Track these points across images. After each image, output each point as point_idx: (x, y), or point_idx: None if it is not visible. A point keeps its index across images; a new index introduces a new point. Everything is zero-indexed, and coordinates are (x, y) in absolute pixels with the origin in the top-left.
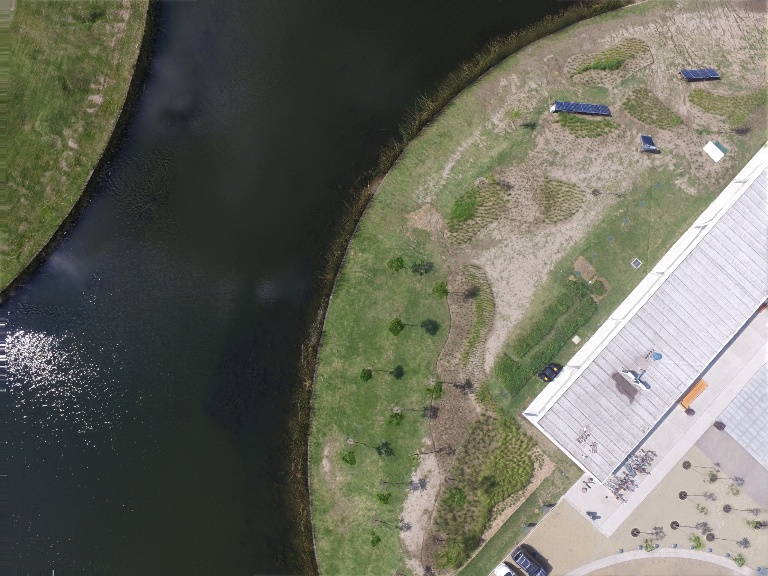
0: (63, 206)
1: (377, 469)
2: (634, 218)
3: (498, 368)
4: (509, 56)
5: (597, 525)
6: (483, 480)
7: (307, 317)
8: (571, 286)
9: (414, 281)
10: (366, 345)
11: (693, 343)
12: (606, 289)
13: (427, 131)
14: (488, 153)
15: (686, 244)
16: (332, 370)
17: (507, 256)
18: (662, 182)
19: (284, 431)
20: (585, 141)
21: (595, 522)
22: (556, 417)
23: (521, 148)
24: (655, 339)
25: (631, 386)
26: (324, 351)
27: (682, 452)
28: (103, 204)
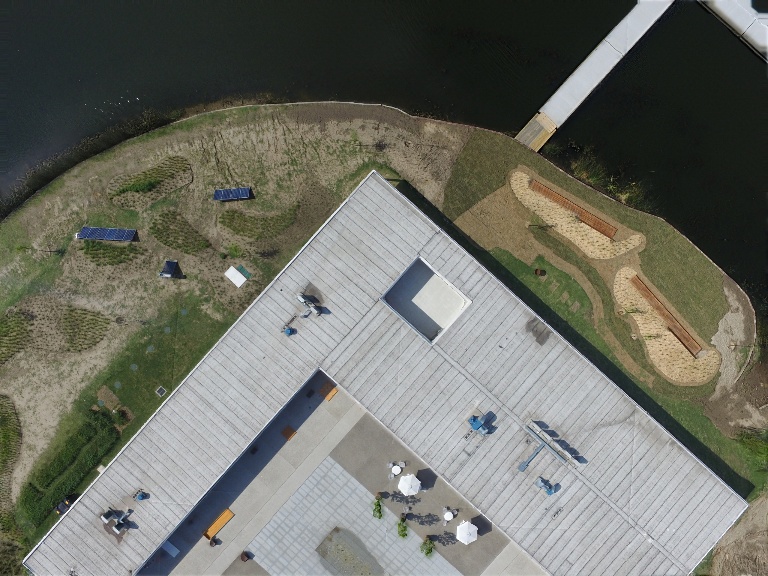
0: None
1: None
2: (158, 345)
3: (21, 499)
4: (56, 178)
5: None
6: None
7: None
8: (91, 416)
9: None
10: None
11: (182, 482)
12: (130, 418)
13: None
14: (23, 280)
15: None
16: None
17: (34, 385)
18: (188, 308)
19: None
20: (107, 269)
21: None
22: (43, 557)
23: (50, 276)
24: (143, 478)
25: None
26: None
27: None
28: None
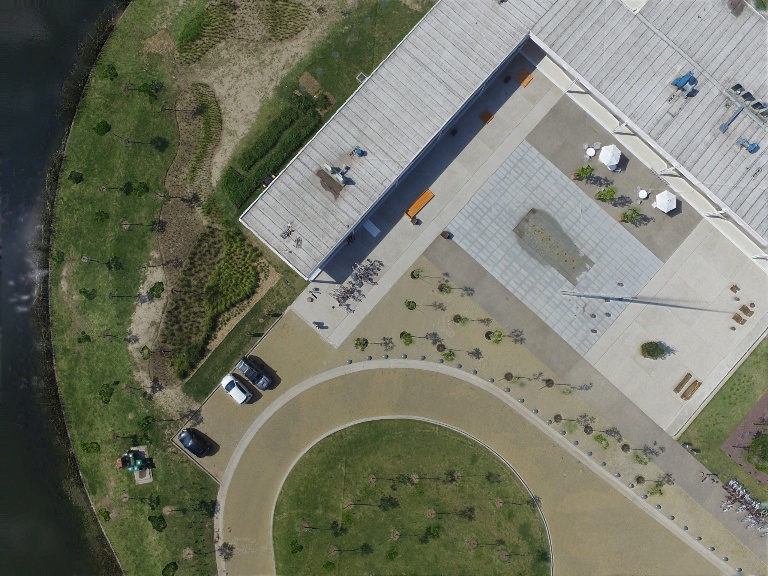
0: None
1: (108, 284)
2: (359, 34)
3: (223, 180)
4: None
5: (324, 335)
6: (206, 289)
7: (52, 146)
8: (294, 99)
9: (145, 101)
10: (101, 166)
11: (398, 140)
12: (331, 103)
13: None
14: None
15: None
16: (71, 192)
17: (235, 74)
18: None
19: (28, 256)
20: None
21: (322, 332)
22: (260, 213)
23: None
24: (360, 136)
25: (335, 182)
26: (64, 175)
27: (410, 262)
28: None
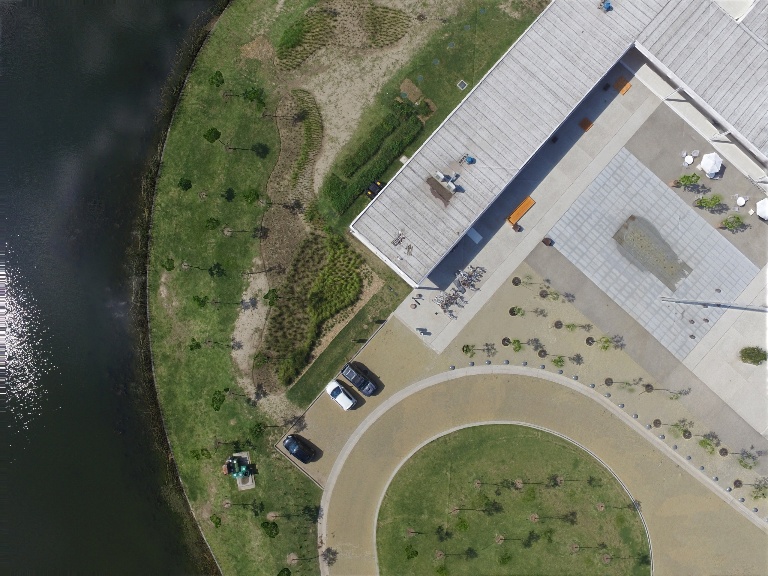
0: None
1: (209, 290)
2: (459, 41)
3: (326, 187)
4: None
5: (428, 342)
6: (311, 296)
7: (148, 151)
8: (396, 106)
9: (245, 107)
10: (200, 172)
11: (507, 148)
12: (432, 110)
13: None
14: None
15: None
16: (169, 199)
17: (335, 81)
18: (487, 7)
19: (125, 262)
20: None
21: (426, 339)
22: (371, 221)
23: None
24: (469, 144)
25: (445, 190)
26: (162, 181)
27: (511, 269)
28: None
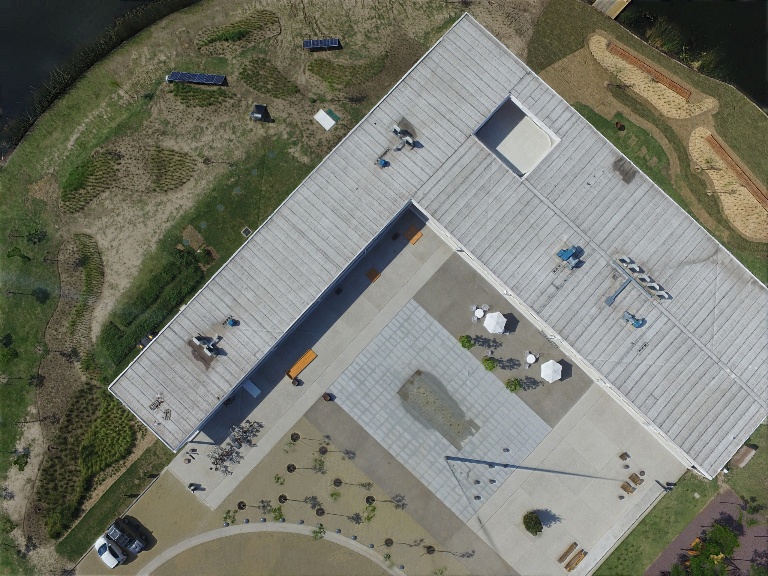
0: None
1: None
2: (245, 187)
3: (102, 336)
4: (143, 30)
5: (201, 497)
6: (82, 449)
7: None
8: (176, 254)
9: (27, 250)
10: None
11: (272, 309)
12: (214, 258)
13: (58, 103)
14: (110, 124)
15: None
16: None
17: (118, 225)
18: (275, 151)
19: None
20: (196, 110)
21: (199, 494)
22: (129, 383)
23: (137, 118)
24: (233, 305)
25: None
26: None
27: (290, 424)
28: None
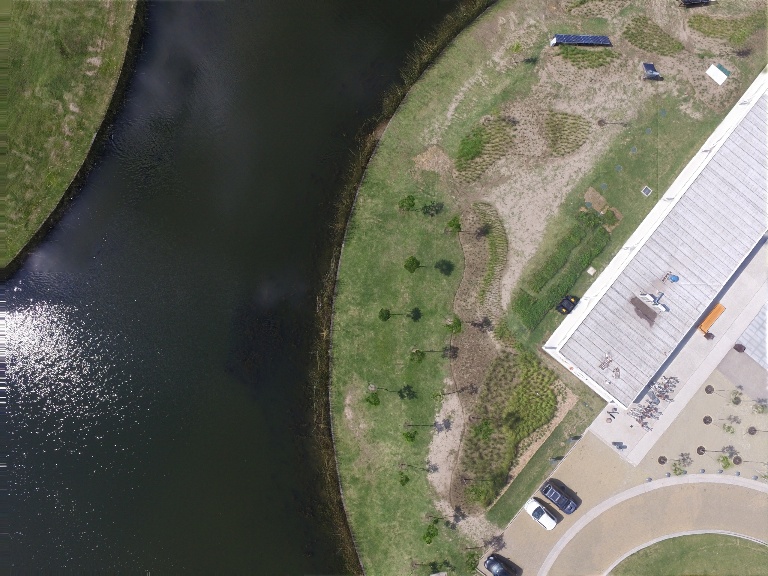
0: (68, 171)
1: (400, 413)
2: (641, 146)
3: (515, 304)
4: None
5: (624, 455)
6: (507, 416)
7: (320, 268)
8: (583, 217)
9: (425, 223)
10: (381, 290)
11: (709, 263)
12: (618, 218)
13: (428, 74)
14: (491, 91)
15: (695, 168)
16: (349, 318)
17: (517, 192)
18: (667, 109)
19: (304, 383)
20: (588, 72)
21: (621, 452)
22: (577, 345)
23: (524, 83)
24: (671, 261)
25: (650, 309)
26: (339, 300)
27: (704, 377)
28: (108, 167)
